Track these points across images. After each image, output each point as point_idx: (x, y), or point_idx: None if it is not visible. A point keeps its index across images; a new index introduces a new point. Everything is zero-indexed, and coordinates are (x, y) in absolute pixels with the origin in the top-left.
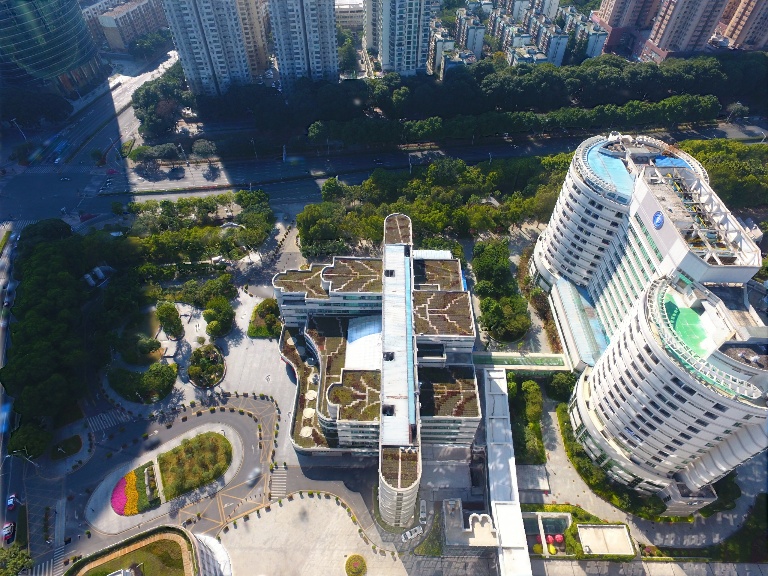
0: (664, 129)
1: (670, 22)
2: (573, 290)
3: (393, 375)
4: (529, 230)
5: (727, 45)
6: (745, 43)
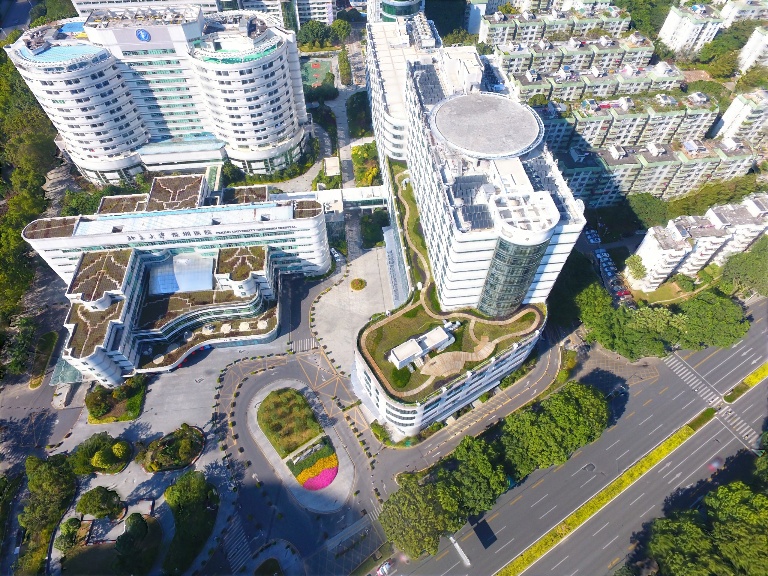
0: None
1: None
2: (152, 146)
3: (235, 218)
4: (51, 186)
5: None
6: None
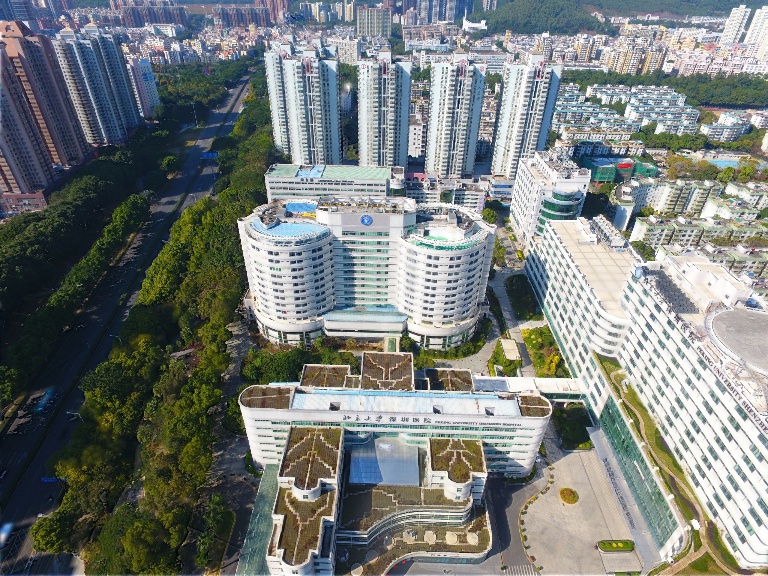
0: (133, 234)
1: (14, 171)
2: (337, 312)
3: (457, 407)
4: None
5: (62, 168)
6: (69, 161)
